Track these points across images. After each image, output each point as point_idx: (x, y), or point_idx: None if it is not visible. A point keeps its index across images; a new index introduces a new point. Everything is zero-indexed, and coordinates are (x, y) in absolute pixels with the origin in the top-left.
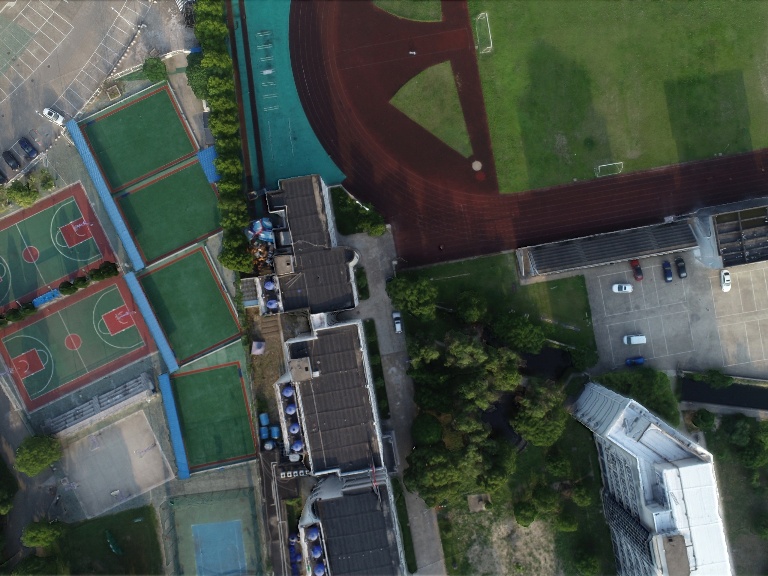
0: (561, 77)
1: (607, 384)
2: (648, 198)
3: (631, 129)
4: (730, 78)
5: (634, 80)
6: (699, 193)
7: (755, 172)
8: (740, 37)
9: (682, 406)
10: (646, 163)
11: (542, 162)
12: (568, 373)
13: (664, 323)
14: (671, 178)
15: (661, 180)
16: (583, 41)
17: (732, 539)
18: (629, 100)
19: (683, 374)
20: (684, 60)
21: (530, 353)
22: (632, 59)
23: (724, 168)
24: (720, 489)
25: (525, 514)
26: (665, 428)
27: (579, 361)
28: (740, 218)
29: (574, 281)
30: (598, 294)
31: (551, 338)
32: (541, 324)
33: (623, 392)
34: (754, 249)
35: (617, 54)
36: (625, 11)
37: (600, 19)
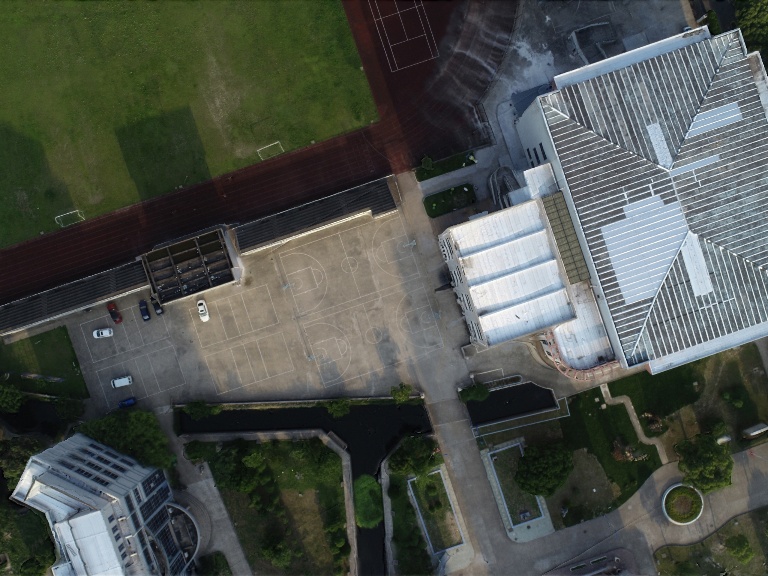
0: (11, 134)
1: (86, 432)
2: (117, 240)
3: (89, 175)
4: (178, 110)
5: (83, 126)
6: (166, 228)
7: (218, 199)
8: (181, 68)
9: (182, 440)
10: (109, 206)
11: (6, 220)
12: (63, 424)
13: (151, 361)
14: (136, 217)
15: (126, 221)
16: (27, 95)
17: (252, 562)
18: (82, 147)
19: (168, 410)
20: (129, 99)
21: (9, 412)
22: (78, 106)
23: (186, 200)
24: (232, 515)
25: (24, 571)
26: (74, 479)
27: (58, 413)
28: (170, 253)
29: (56, 333)
30: (82, 342)
31: (43, 392)
32: (30, 380)
33: (100, 438)
34: (191, 281)
35: (63, 103)
36: (63, 59)
37: (40, 71)
